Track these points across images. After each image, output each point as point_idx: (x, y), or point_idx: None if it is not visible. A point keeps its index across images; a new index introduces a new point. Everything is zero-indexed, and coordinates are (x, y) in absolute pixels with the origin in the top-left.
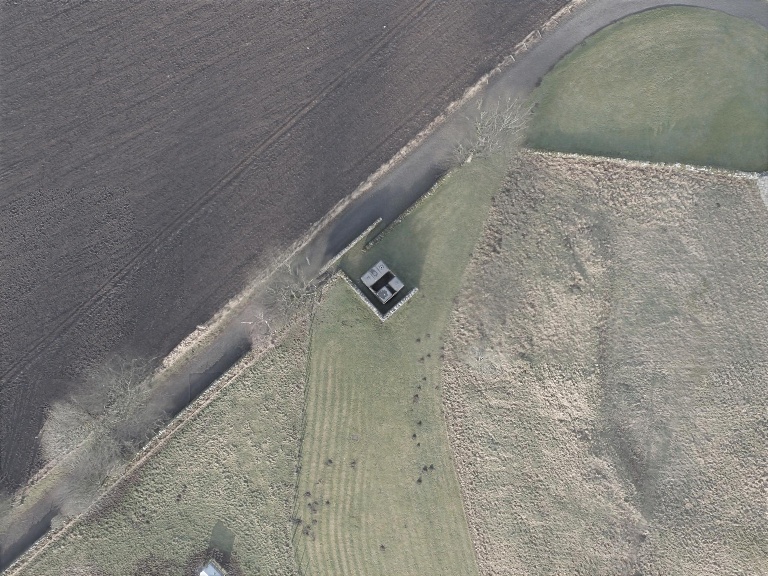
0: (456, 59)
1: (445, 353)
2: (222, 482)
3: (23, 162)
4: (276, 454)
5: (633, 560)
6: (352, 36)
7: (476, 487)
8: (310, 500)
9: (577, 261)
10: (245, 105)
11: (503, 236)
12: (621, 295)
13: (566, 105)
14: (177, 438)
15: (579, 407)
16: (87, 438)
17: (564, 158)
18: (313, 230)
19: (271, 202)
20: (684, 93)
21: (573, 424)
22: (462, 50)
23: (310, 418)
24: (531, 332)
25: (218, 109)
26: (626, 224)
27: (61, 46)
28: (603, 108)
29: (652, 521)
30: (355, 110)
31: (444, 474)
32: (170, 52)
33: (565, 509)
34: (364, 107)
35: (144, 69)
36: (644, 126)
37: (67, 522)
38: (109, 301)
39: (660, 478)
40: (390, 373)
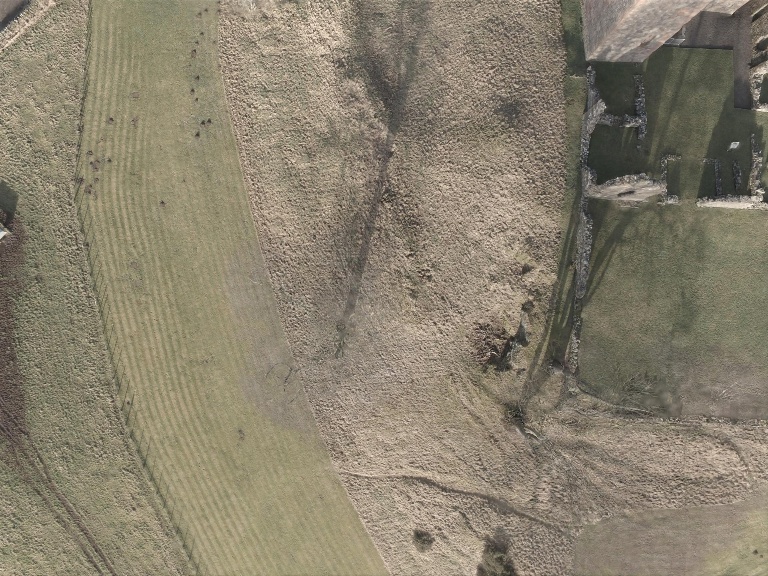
0: None
1: (221, 7)
2: (5, 143)
3: None
4: (59, 114)
5: (383, 178)
6: None
7: (251, 138)
8: (92, 159)
9: None
10: None
11: None
12: None
13: None
14: None
15: (336, 36)
16: None
17: None
18: None
19: None
20: None
21: (332, 55)
22: None
23: (92, 77)
24: None
25: None
26: None
27: None
28: None
29: (398, 134)
30: None
31: (221, 127)
32: None
33: (328, 144)
34: None
35: None
36: None
37: None
38: None
39: (408, 97)
40: (169, 29)
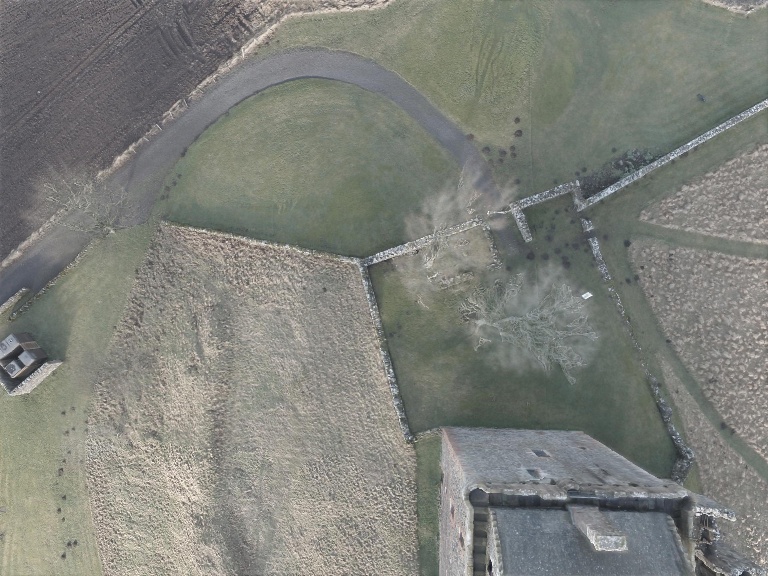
0: (107, 127)
1: (89, 427)
2: None
3: None
4: None
5: None
6: (8, 101)
7: (116, 565)
8: None
9: (198, 341)
10: None
11: (144, 309)
12: (240, 377)
13: (204, 178)
14: None
15: (195, 491)
16: None
17: (198, 233)
18: None
19: None
20: (307, 170)
21: (191, 508)
22: (112, 117)
23: None
24: (162, 410)
25: None
26: (247, 304)
27: None
28: (236, 182)
29: None
30: (9, 176)
31: (87, 550)
32: None
33: None
34: (17, 173)
35: None
36: (270, 203)
37: None
38: None
39: (266, 569)
40: (36, 445)
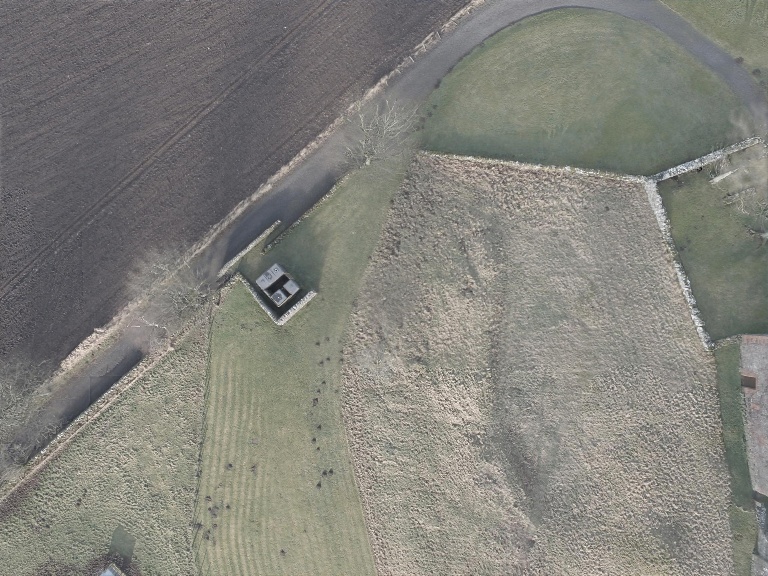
0: (356, 60)
1: (344, 357)
2: (122, 486)
3: None
4: (176, 458)
5: (523, 565)
6: (253, 37)
7: (375, 491)
8: (210, 504)
9: (470, 264)
10: (145, 106)
11: (401, 239)
12: (514, 299)
13: (463, 107)
14: (77, 442)
15: (471, 411)
16: None
17: (460, 161)
18: (213, 232)
19: (171, 204)
20: (577, 95)
21: (466, 428)
22: (362, 51)
23: (210, 422)
24: (427, 336)
25: (118, 110)
26: (519, 227)
27: None
28: (499, 110)
29: (540, 526)
30: (255, 111)
31: (343, 478)
32: (70, 52)
33: (459, 514)
34: (264, 108)
35: (44, 69)
36: (538, 129)
37: None
38: (8, 303)
39: (550, 483)
40: (290, 377)
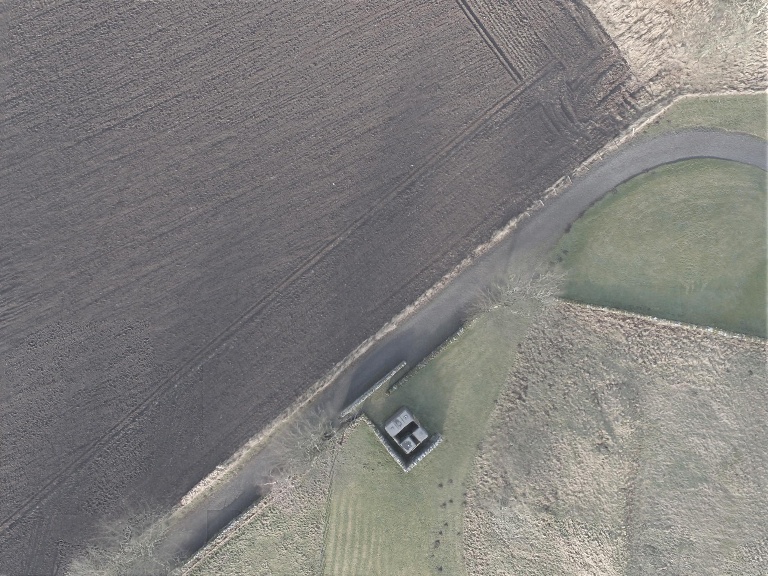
0: (484, 201)
1: (468, 499)
2: None
3: (42, 294)
4: None
5: None
6: (379, 174)
7: None
8: None
9: (605, 419)
10: (269, 240)
11: (529, 384)
12: (649, 455)
13: (596, 255)
14: (194, 575)
15: (604, 568)
16: None
17: (593, 310)
18: (336, 370)
19: (293, 340)
20: (717, 252)
21: None
22: (490, 192)
23: (329, 559)
24: (556, 485)
25: (241, 243)
26: (655, 383)
27: (82, 175)
28: (634, 261)
29: None
30: (380, 249)
31: None
32: (193, 184)
33: None
34: (390, 246)
35: (166, 200)
36: (675, 283)
37: None
38: (127, 436)
39: None
40: (411, 517)
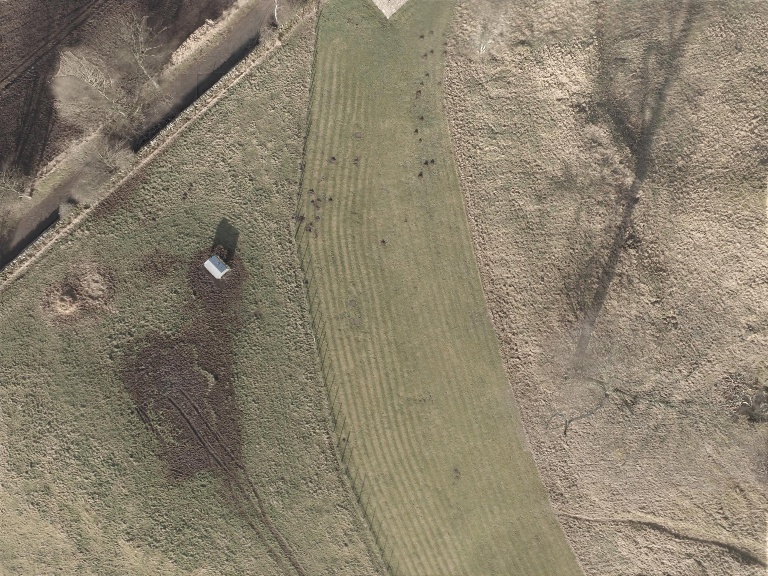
0: None
1: (448, 49)
2: (227, 181)
3: None
4: (281, 153)
5: (627, 224)
6: None
7: (475, 179)
8: (313, 197)
9: None
10: None
11: None
12: None
13: None
14: (184, 136)
15: (577, 81)
16: (96, 133)
17: None
18: None
19: None
20: None
21: (571, 99)
22: None
23: (315, 117)
24: (532, 19)
25: None
26: None
27: None
28: None
29: (646, 181)
30: None
31: (444, 168)
32: None
33: (562, 187)
34: None
35: None
36: None
37: (75, 216)
38: None
39: (654, 143)
40: (394, 70)
